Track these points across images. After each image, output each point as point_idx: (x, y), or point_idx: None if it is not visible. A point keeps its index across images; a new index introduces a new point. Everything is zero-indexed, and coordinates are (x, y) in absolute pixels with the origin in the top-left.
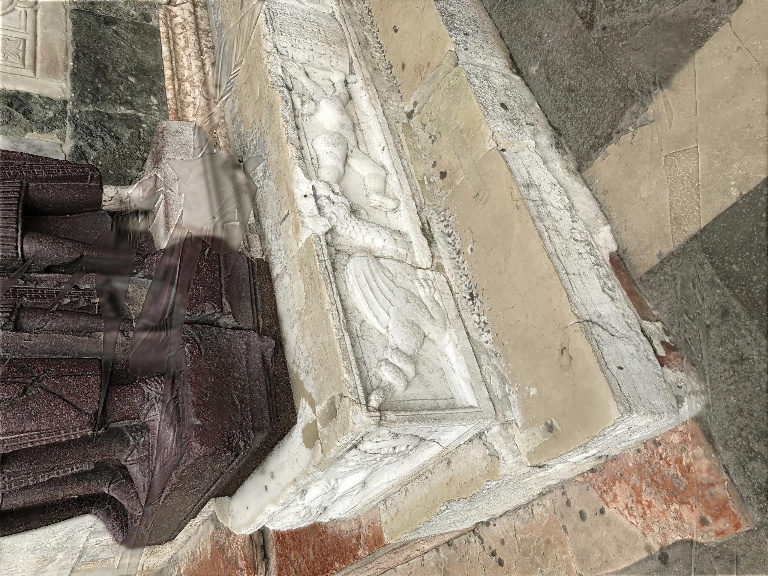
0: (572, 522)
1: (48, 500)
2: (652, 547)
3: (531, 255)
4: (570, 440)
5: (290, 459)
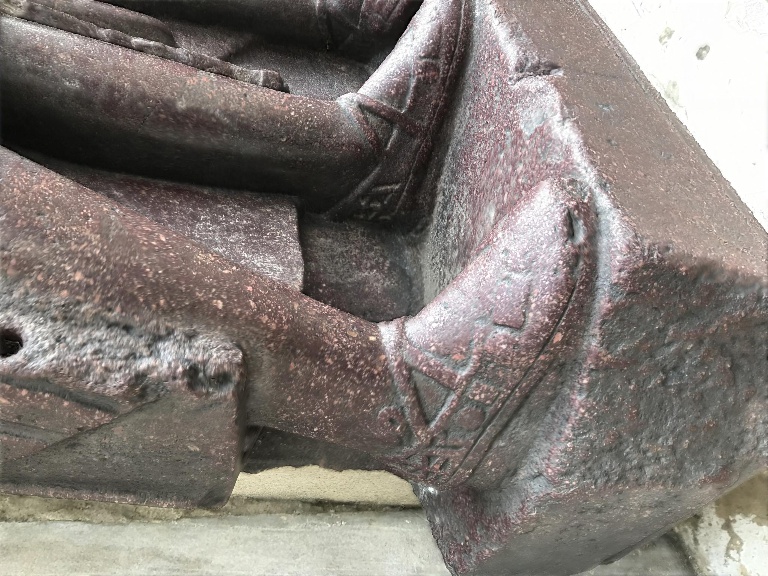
0: None
1: (166, 71)
2: None
3: None
4: None
5: None
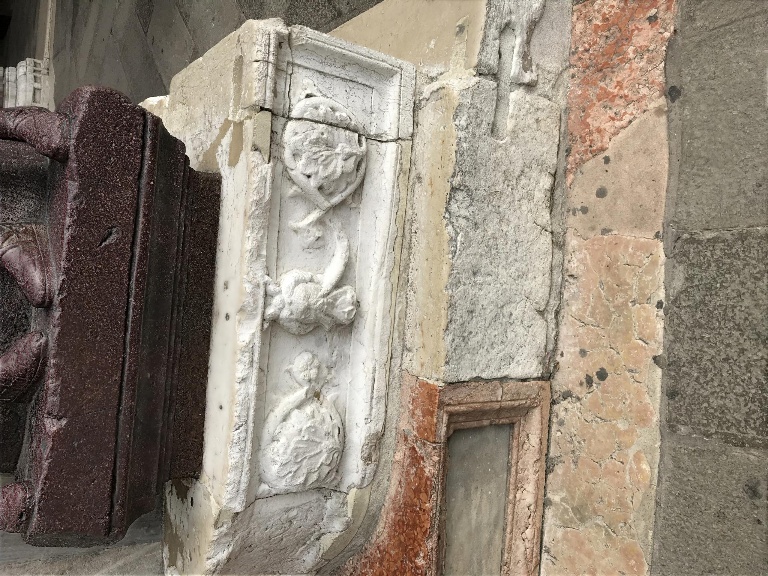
0: (602, 214)
1: None
2: (660, 106)
3: (367, 17)
4: (478, 5)
5: (232, 216)
